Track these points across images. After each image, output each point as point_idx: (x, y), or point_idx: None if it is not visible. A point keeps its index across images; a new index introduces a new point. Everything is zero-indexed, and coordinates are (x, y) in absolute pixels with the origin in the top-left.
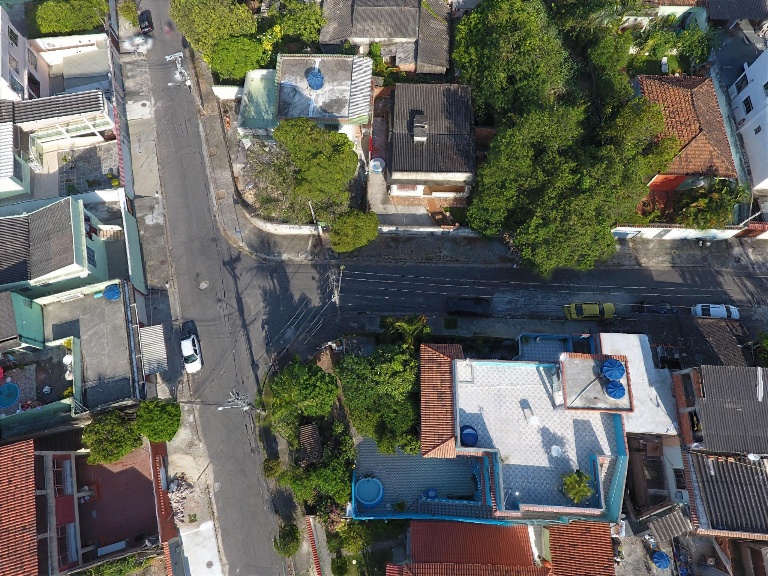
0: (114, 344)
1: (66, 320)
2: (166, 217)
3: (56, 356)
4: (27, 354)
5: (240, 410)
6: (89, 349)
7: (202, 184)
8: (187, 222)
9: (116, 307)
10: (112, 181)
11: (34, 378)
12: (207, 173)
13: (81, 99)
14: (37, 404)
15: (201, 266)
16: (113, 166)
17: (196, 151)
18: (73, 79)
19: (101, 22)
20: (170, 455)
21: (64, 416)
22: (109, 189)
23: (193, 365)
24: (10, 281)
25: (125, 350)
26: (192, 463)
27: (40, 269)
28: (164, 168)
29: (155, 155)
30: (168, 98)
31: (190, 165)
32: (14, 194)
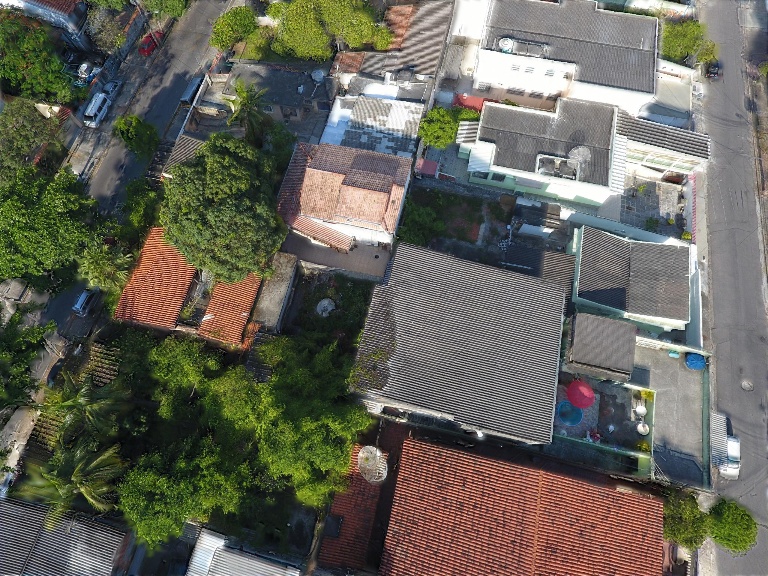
0: (684, 417)
1: (637, 365)
2: (711, 289)
3: (621, 397)
4: (593, 380)
5: (765, 545)
6: (657, 408)
7: (755, 271)
8: (735, 306)
9: (691, 378)
10: (686, 233)
11: (598, 409)
12: (761, 261)
13: (690, 139)
14: (603, 440)
15: (747, 363)
16: (671, 211)
17: (751, 231)
18: (649, 103)
19: (687, 54)
20: (681, 551)
21: (599, 456)
22: (682, 240)
23: (732, 472)
24: (611, 305)
25: (696, 430)
26: (700, 572)
27: (642, 306)
28: (713, 234)
29: (705, 215)
30: (724, 158)
31: (743, 244)
32: (589, 203)
